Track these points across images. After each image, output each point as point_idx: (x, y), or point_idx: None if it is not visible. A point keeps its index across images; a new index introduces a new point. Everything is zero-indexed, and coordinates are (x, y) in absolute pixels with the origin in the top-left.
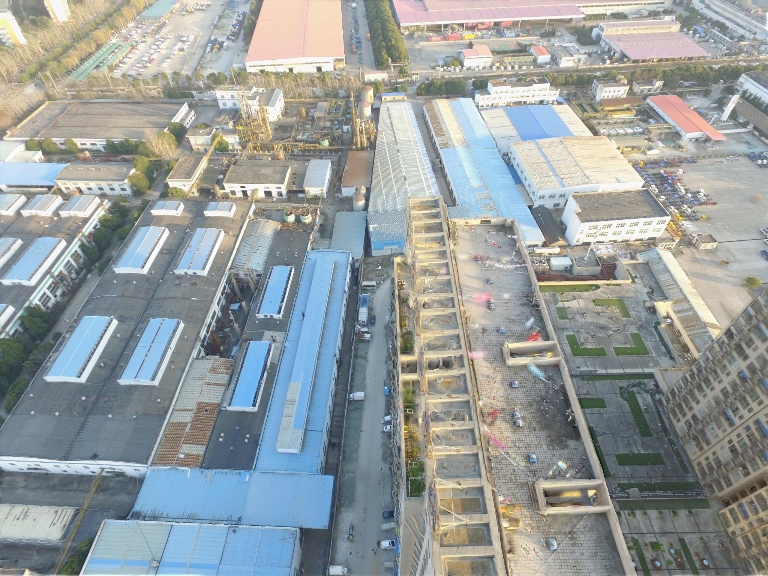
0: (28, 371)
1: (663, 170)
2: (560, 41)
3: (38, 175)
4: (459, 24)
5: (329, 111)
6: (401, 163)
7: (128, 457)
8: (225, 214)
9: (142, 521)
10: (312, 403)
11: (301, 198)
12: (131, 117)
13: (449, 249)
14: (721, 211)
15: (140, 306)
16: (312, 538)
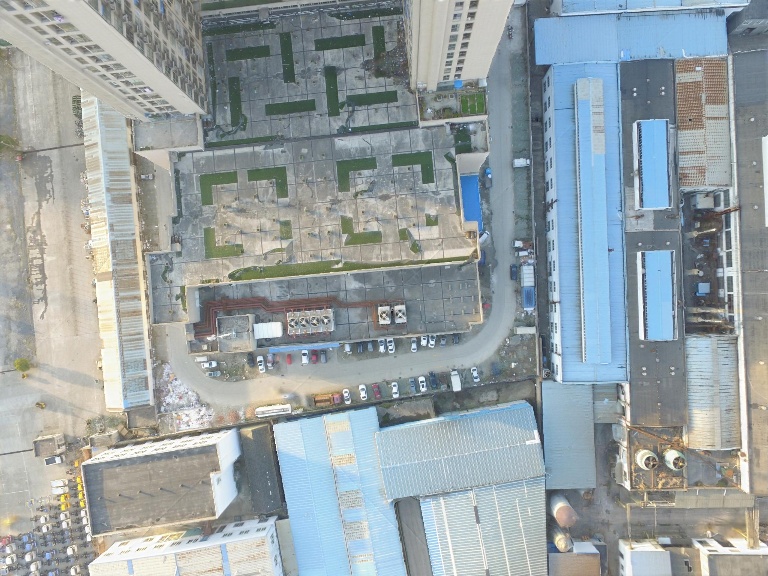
0: None
1: None
2: None
3: None
4: None
5: None
6: None
7: (756, 57)
8: None
9: (712, 4)
10: (573, 139)
11: None
12: None
13: None
14: None
15: None
16: None
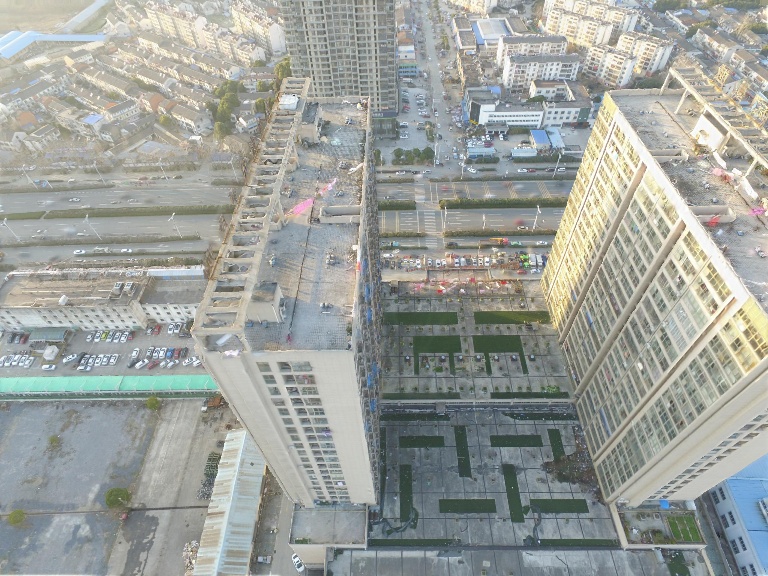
0: None
1: None
2: None
3: None
4: None
5: None
6: None
7: None
8: None
9: None
10: None
11: None
12: None
13: None
14: None
15: None
16: None
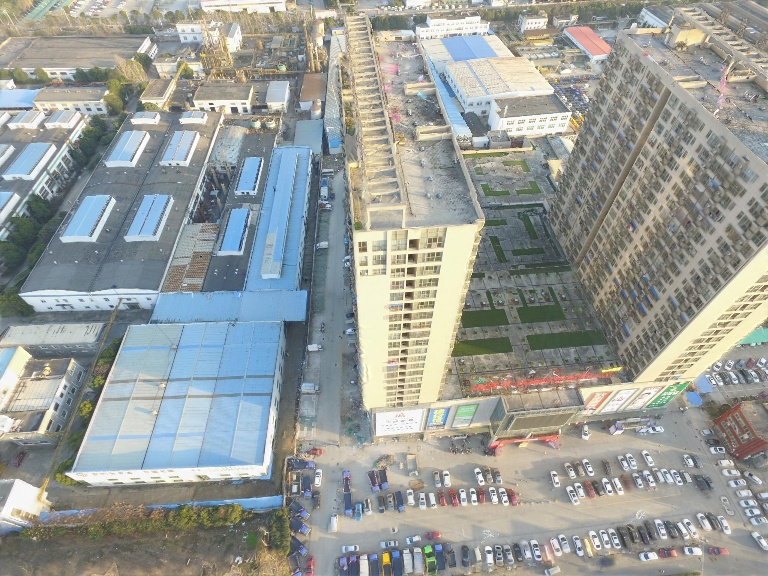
0: (43, 238)
1: (573, 85)
2: None
3: (15, 98)
4: None
5: (284, 43)
6: None
7: (142, 286)
8: (198, 121)
9: (160, 324)
10: (286, 248)
11: (264, 113)
12: (97, 49)
13: (371, 37)
14: None
15: (133, 190)
16: (293, 330)
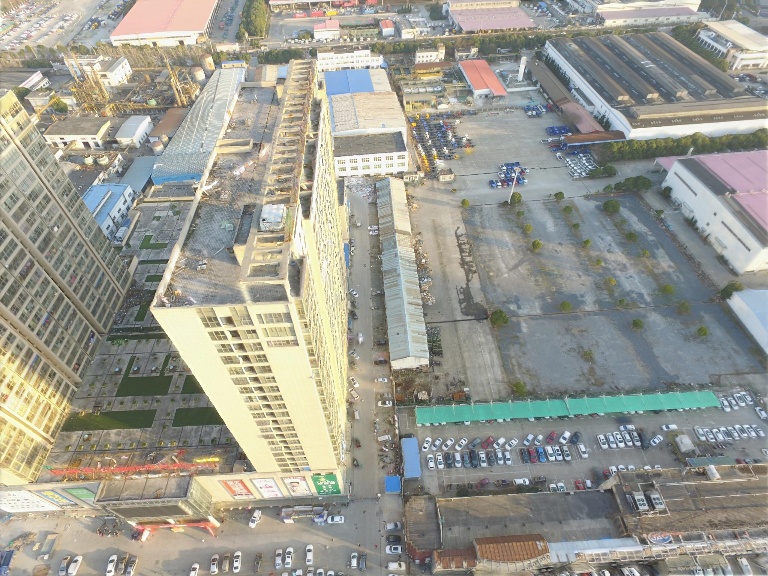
0: None
1: (442, 121)
2: (414, 17)
3: None
4: (326, 2)
5: None
6: (209, 117)
7: None
8: None
9: None
10: None
11: (116, 148)
12: None
13: None
14: (476, 152)
15: None
16: None
